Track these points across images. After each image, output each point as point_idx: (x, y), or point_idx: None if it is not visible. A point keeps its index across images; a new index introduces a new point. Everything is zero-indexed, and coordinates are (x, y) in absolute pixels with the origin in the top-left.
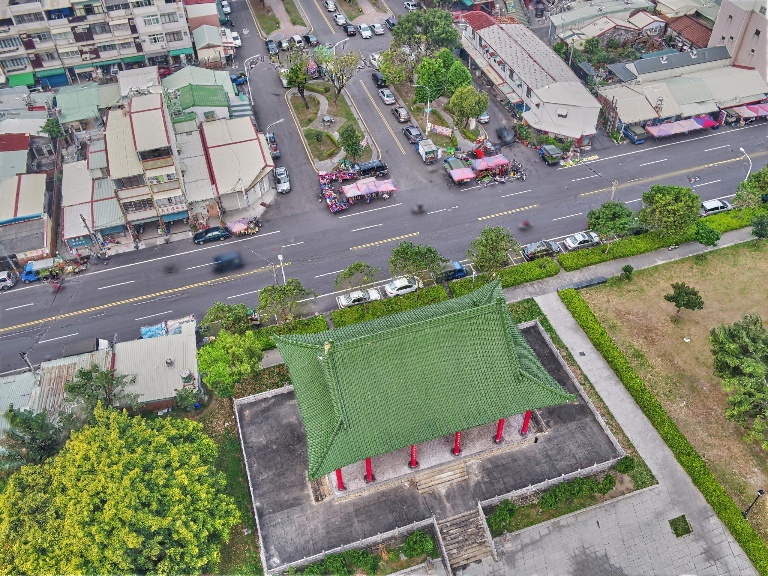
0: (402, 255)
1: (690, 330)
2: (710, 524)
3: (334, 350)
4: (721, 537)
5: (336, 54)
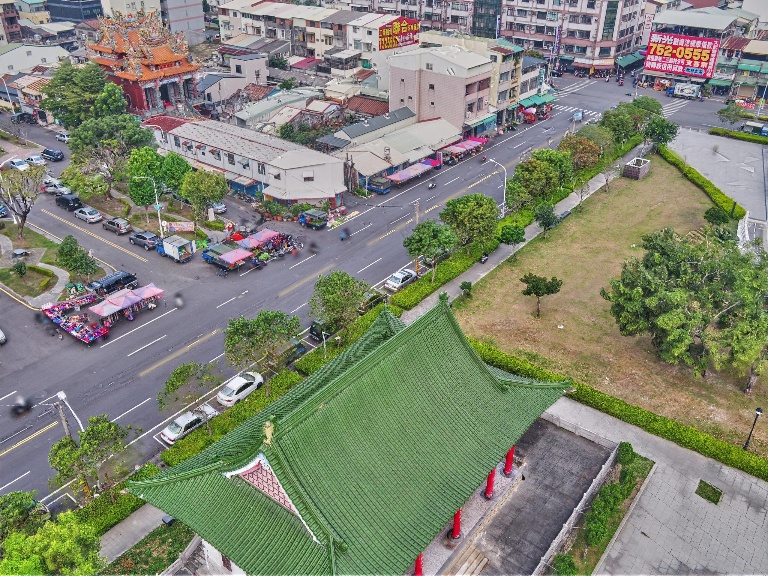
0: (244, 331)
1: (556, 318)
2: (727, 476)
3: (279, 434)
4: (746, 482)
5: (7, 172)
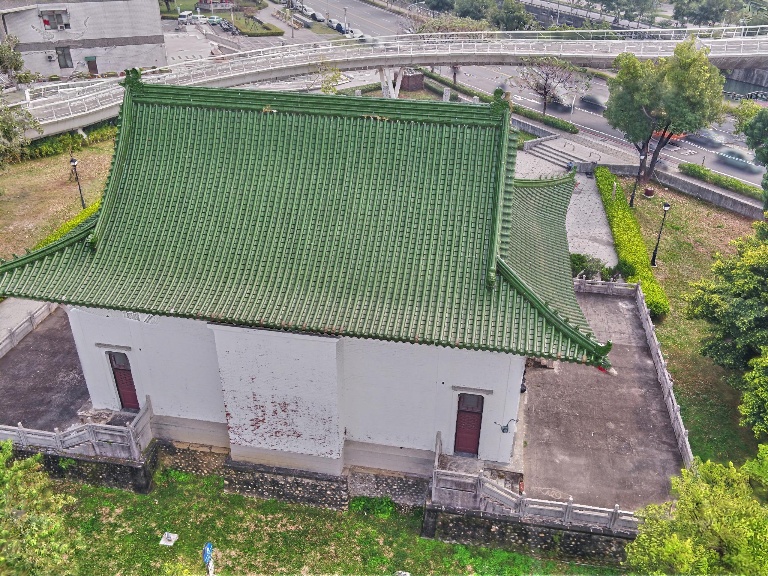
0: (3, 531)
1: None
2: None
3: None
4: None
5: None
